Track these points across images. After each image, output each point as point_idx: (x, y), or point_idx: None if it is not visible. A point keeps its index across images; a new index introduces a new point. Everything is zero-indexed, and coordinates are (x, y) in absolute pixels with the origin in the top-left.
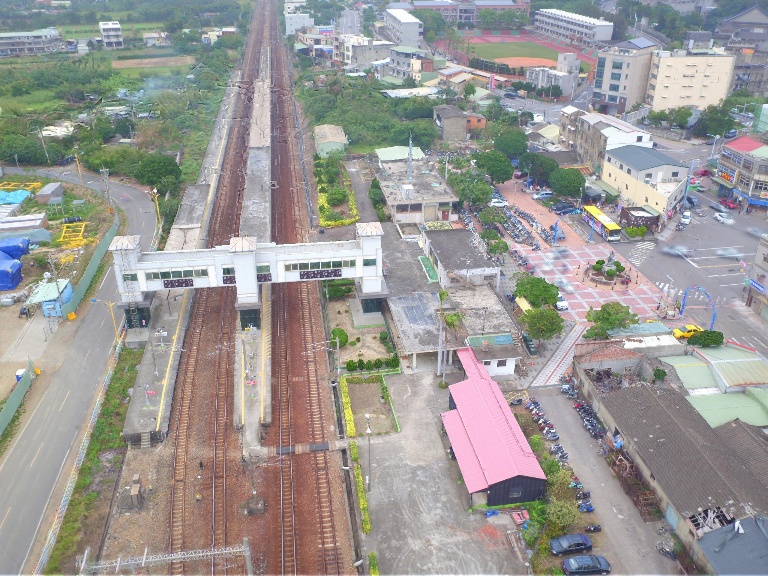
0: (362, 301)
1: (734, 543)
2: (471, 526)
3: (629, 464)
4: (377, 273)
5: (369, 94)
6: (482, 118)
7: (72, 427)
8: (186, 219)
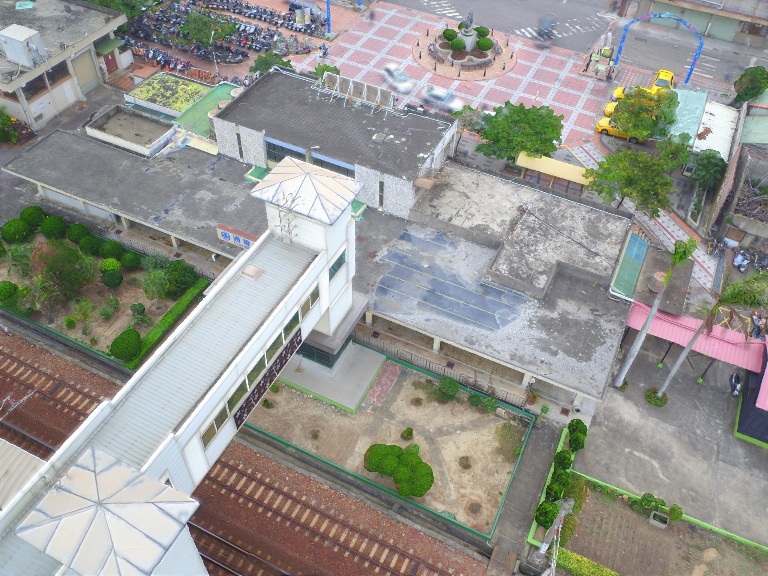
0: (303, 347)
1: None
2: None
3: None
4: (348, 276)
5: None
6: None
7: None
8: None
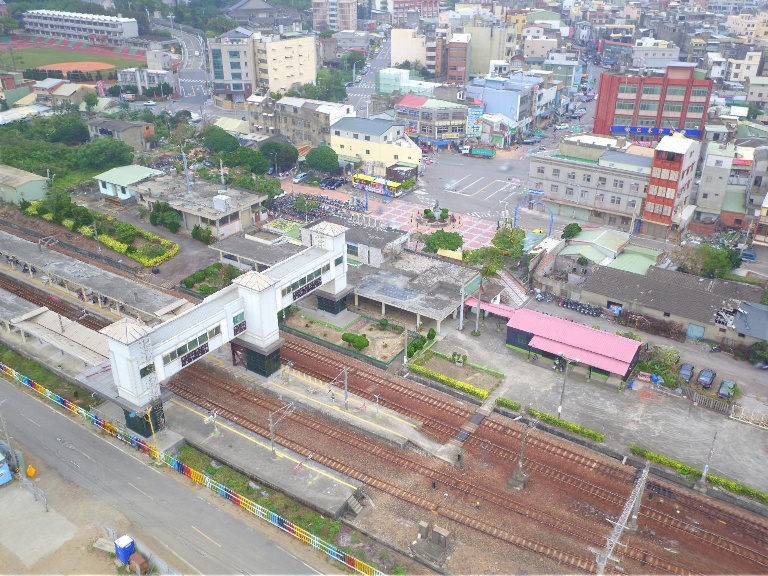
0: (325, 305)
1: (750, 320)
2: (634, 398)
3: (642, 317)
4: (344, 270)
5: None
6: (150, 124)
7: (265, 547)
8: (8, 309)
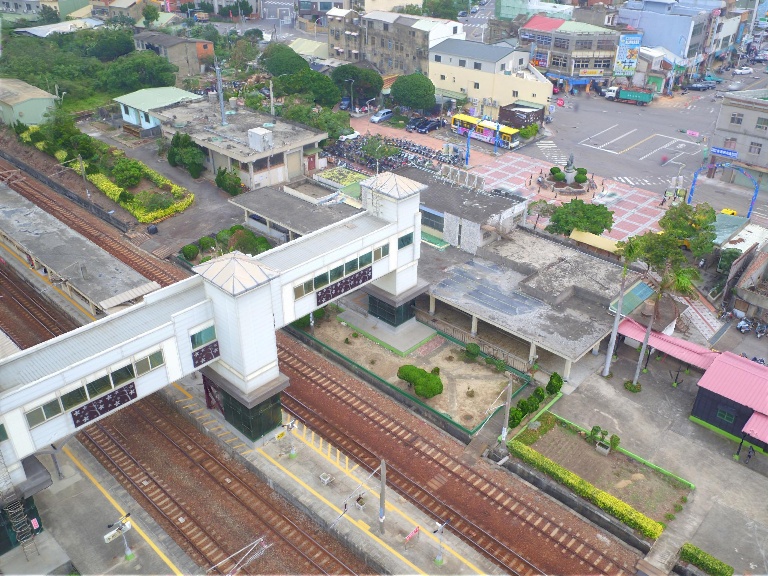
0: (380, 310)
1: None
2: None
3: None
4: (414, 255)
5: (8, 34)
6: (208, 42)
7: None
8: None
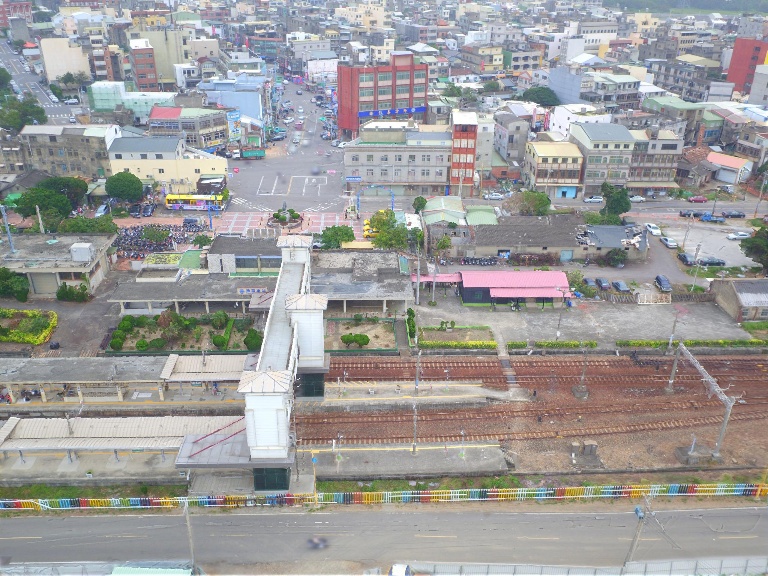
0: None
1: (599, 237)
2: (580, 312)
3: (529, 255)
4: None
5: None
6: None
7: None
8: None
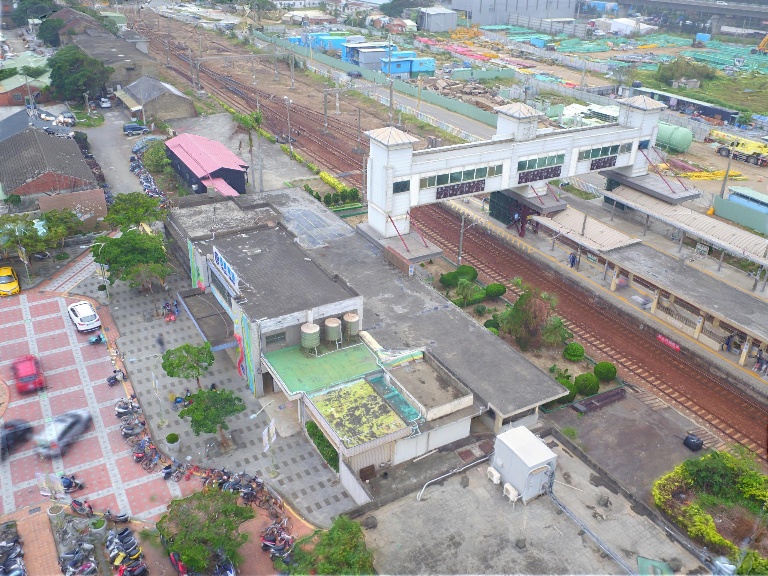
0: None
1: None
2: None
3: (93, 169)
4: None
5: None
6: None
7: None
8: None
